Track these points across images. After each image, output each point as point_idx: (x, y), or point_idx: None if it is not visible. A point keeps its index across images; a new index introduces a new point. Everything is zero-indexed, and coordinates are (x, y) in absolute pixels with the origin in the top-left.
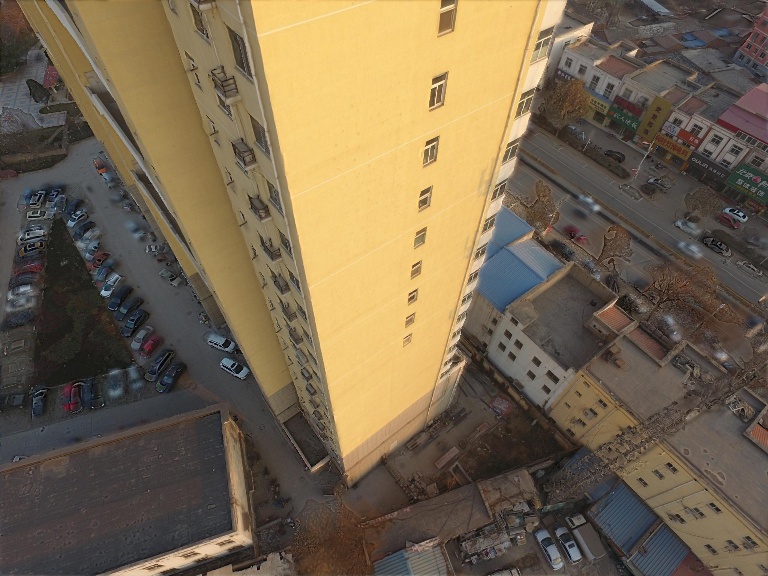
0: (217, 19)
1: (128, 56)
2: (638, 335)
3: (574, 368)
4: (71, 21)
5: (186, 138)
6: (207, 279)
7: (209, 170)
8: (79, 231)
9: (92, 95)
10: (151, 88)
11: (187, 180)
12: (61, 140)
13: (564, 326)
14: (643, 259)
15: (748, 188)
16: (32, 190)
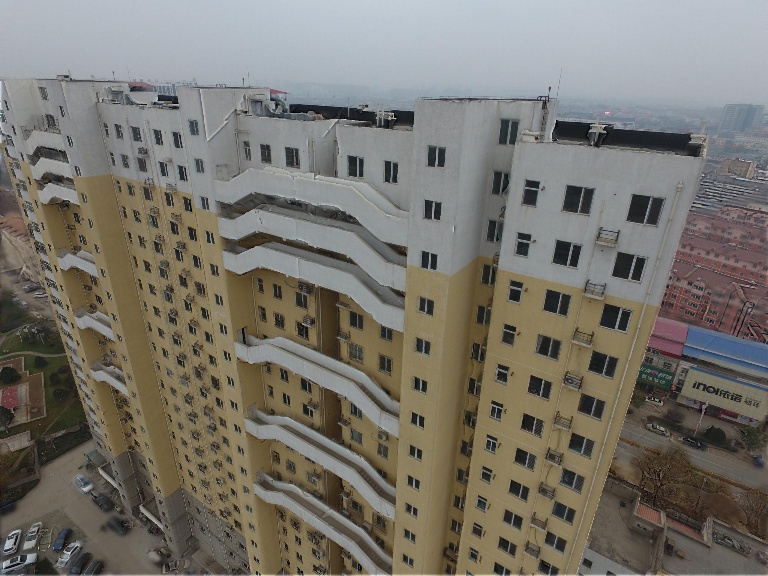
0: (575, 392)
1: (444, 408)
2: (672, 524)
3: (651, 571)
4: (357, 387)
5: (445, 451)
6: (411, 569)
7: (446, 470)
8: (75, 569)
9: (273, 426)
10: (445, 424)
11: (438, 482)
12: (30, 464)
13: (615, 533)
14: (615, 454)
15: (652, 380)
16: (0, 532)
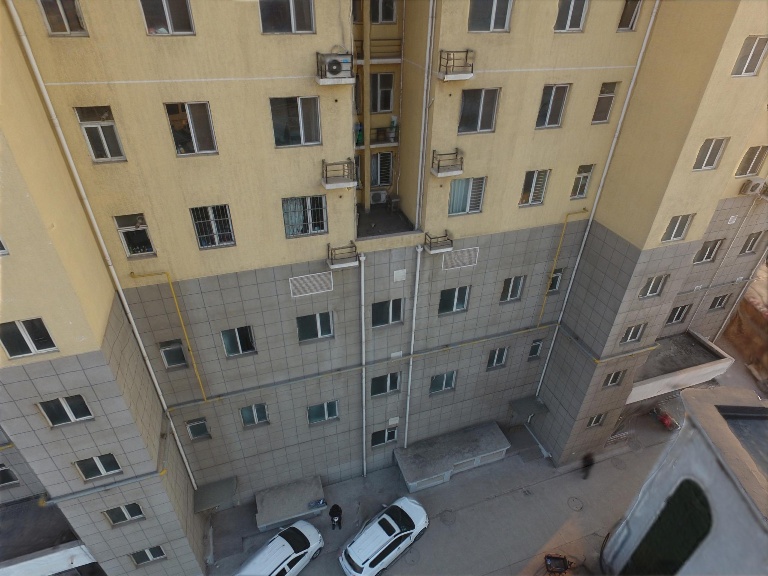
0: None
1: None
2: None
3: None
4: None
5: None
6: None
7: None
8: None
9: None
10: None
11: None
12: None
13: None
14: None
15: None
16: None
